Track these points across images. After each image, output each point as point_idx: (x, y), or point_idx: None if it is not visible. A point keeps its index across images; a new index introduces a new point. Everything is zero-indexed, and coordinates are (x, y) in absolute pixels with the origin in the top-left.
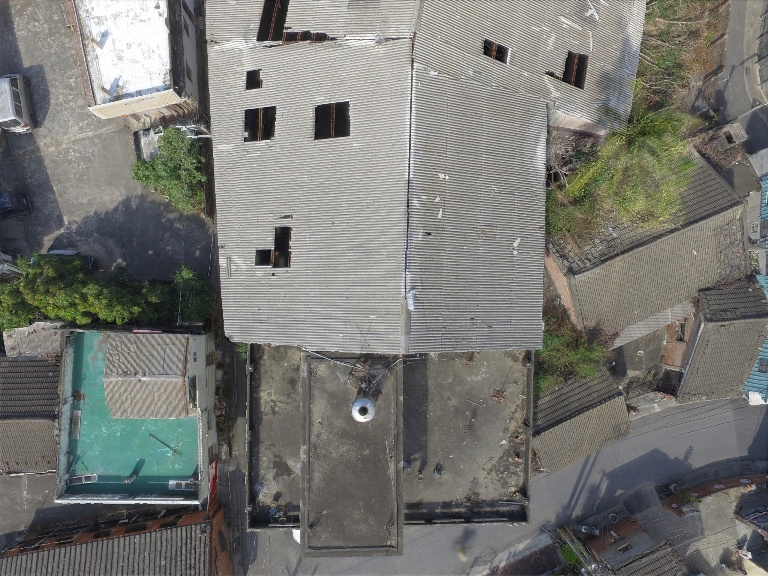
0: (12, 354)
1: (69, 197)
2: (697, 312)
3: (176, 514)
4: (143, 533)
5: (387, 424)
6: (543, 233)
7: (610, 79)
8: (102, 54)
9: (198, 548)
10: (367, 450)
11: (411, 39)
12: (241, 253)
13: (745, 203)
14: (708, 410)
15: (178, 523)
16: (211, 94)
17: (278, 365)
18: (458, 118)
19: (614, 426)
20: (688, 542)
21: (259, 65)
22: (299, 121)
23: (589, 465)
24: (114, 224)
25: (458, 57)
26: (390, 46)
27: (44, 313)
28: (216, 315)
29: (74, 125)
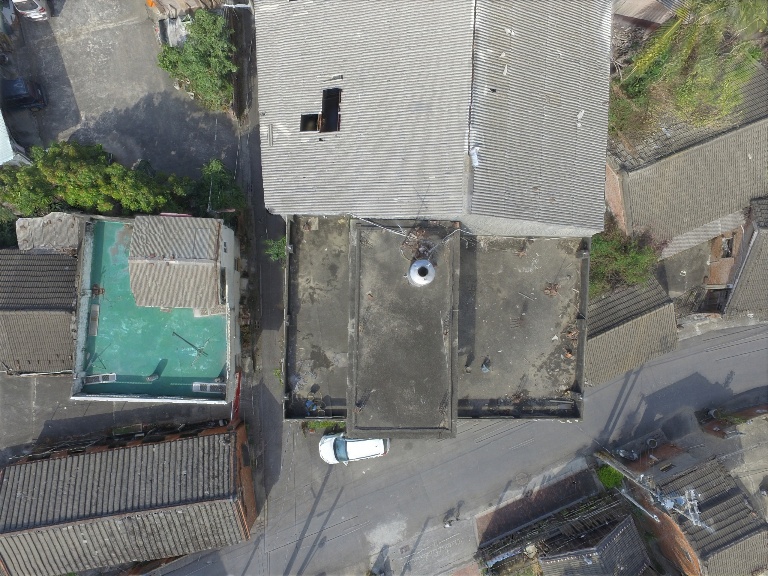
0: (25, 246)
1: (87, 91)
2: (748, 223)
3: (195, 429)
4: (162, 442)
5: (442, 298)
6: (606, 109)
7: None
8: None
9: (222, 458)
10: (420, 325)
11: None
12: (284, 119)
13: None
14: (750, 334)
15: (199, 434)
16: None
17: (318, 250)
18: None
19: (661, 338)
20: (742, 450)
21: None
22: None
23: (628, 388)
24: (135, 121)
25: None
26: None
27: (62, 198)
28: (242, 220)
29: (93, 15)
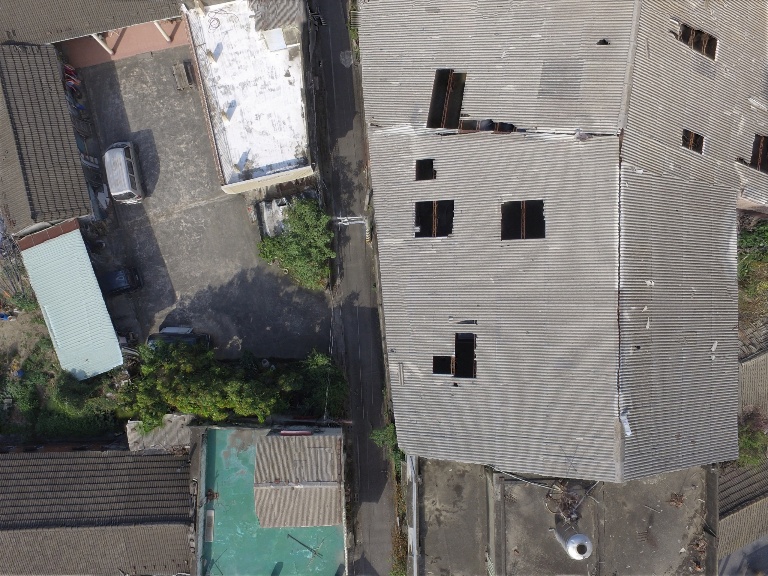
0: (136, 448)
1: (181, 270)
2: None
3: None
4: None
5: None
6: (736, 333)
7: None
8: (230, 126)
9: None
10: None
11: (618, 136)
12: (416, 359)
13: None
14: None
15: None
16: (374, 183)
17: (442, 471)
18: (661, 218)
19: None
20: None
21: (431, 154)
22: (482, 218)
23: None
24: (229, 299)
25: (660, 152)
26: (593, 143)
27: (176, 408)
28: None
29: (185, 194)
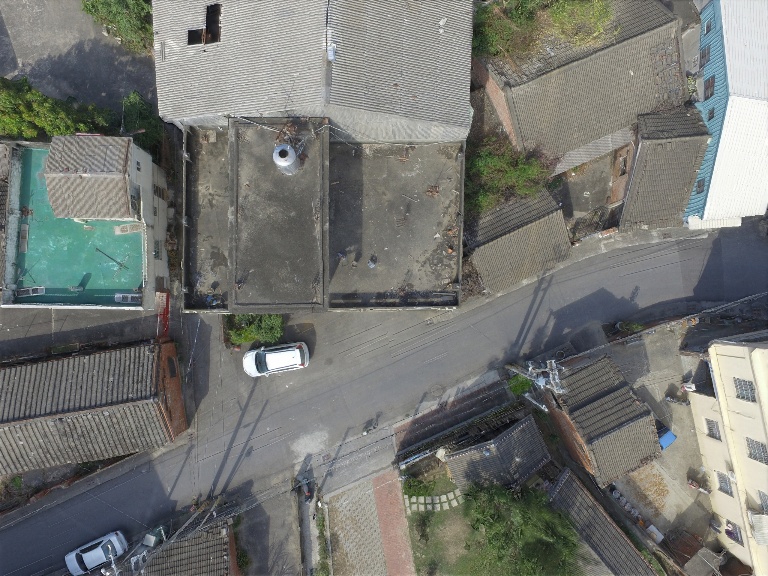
0: None
1: (23, 40)
2: (637, 138)
3: None
4: (93, 354)
5: (313, 187)
6: (470, 18)
7: None
8: None
9: (146, 365)
10: (294, 212)
11: None
12: (175, 36)
13: (679, 19)
14: (654, 251)
15: (128, 347)
16: None
17: (216, 160)
18: None
19: (554, 246)
20: (621, 339)
21: None
22: None
23: (537, 304)
24: (67, 66)
25: None
26: None
27: None
28: (168, 154)
29: None
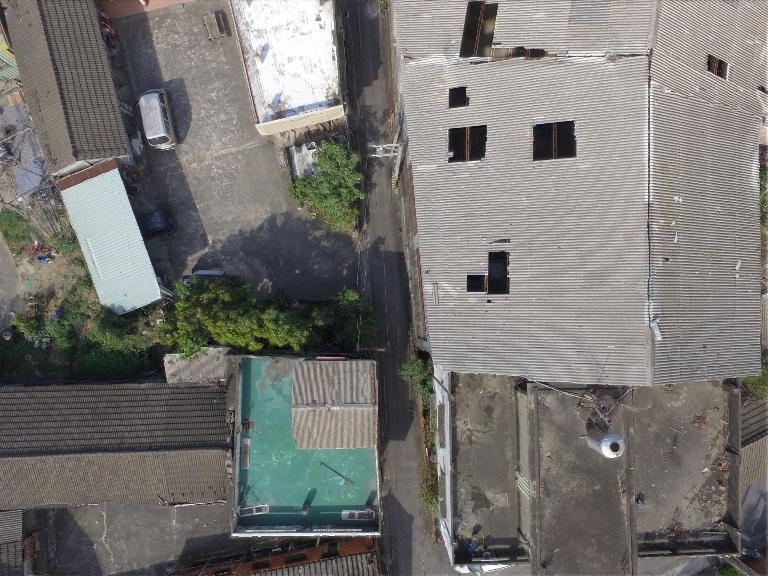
0: (173, 380)
1: (213, 215)
2: None
3: (329, 541)
4: (307, 563)
5: (618, 457)
6: None
7: None
8: (263, 69)
9: None
10: (598, 485)
11: (647, 56)
12: (450, 278)
13: None
14: None
15: (340, 552)
16: (408, 112)
17: (473, 393)
18: (688, 138)
19: None
20: None
21: (464, 82)
22: (514, 141)
23: None
24: (259, 243)
25: (687, 74)
26: (623, 63)
27: (213, 338)
28: None
29: (216, 141)
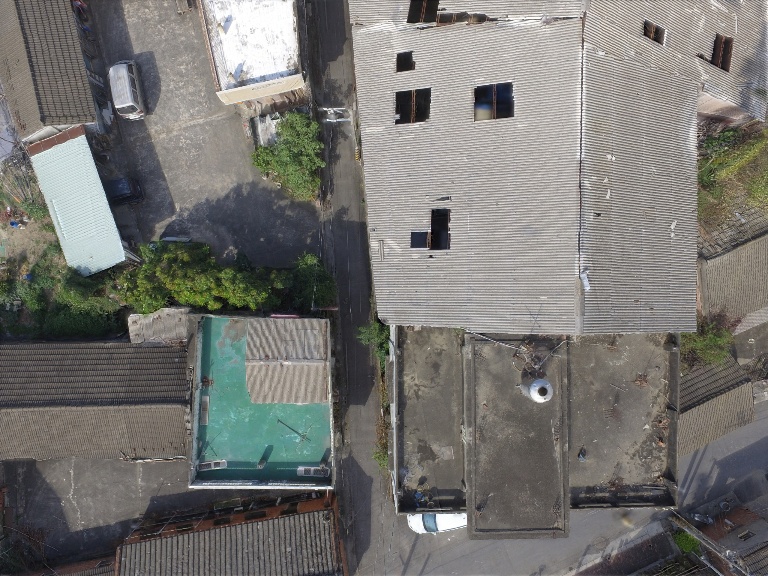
0: (136, 340)
1: (180, 184)
2: None
3: (290, 502)
4: (265, 520)
5: (552, 406)
6: None
7: (752, 62)
8: (226, 39)
9: (323, 535)
10: (532, 432)
11: (581, 19)
12: (395, 235)
13: None
14: None
15: (299, 510)
16: (358, 77)
17: (421, 349)
18: (622, 99)
19: (739, 413)
20: None
21: (411, 47)
22: (457, 102)
23: (700, 453)
24: (226, 211)
25: (622, 37)
26: (558, 26)
27: (174, 298)
28: None
29: (185, 112)
